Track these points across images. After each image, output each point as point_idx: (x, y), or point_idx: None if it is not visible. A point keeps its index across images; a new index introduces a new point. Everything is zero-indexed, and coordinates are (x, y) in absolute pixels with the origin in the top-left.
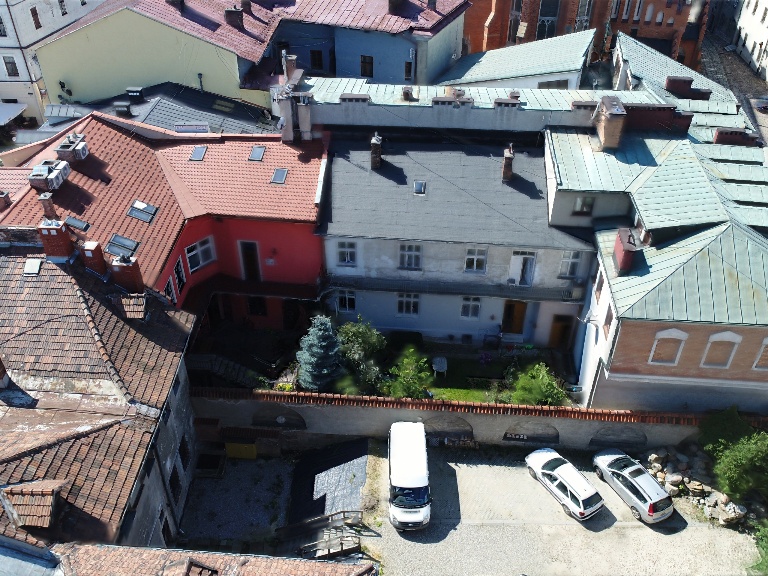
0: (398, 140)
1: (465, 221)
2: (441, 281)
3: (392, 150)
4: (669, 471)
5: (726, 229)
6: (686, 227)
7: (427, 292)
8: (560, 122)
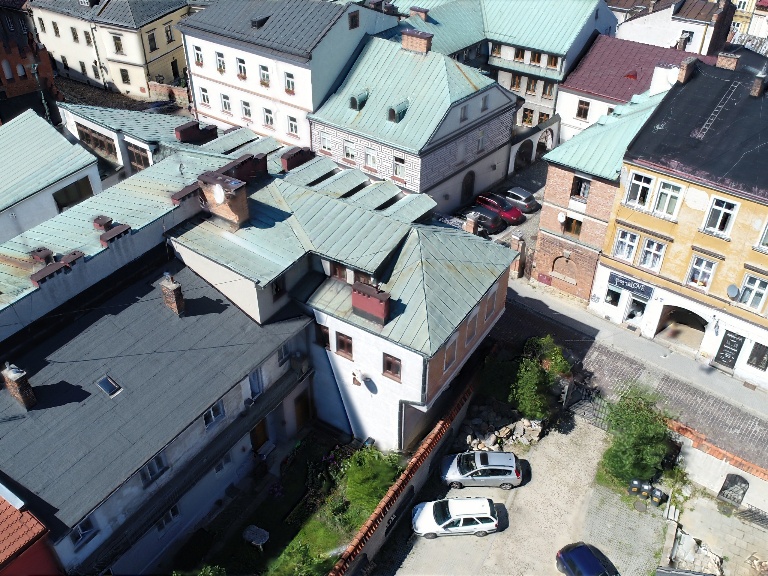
0: (20, 354)
1: (192, 382)
2: (191, 460)
3: (25, 370)
4: (482, 438)
5: (419, 235)
6: (393, 252)
7: (195, 483)
8: (174, 223)
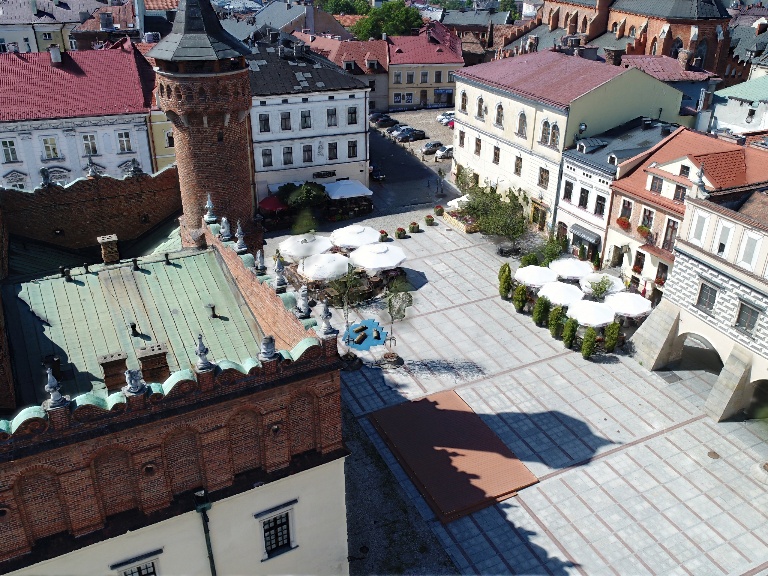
0: None
1: None
2: None
3: None
4: None
5: None
6: None
7: None
8: None
